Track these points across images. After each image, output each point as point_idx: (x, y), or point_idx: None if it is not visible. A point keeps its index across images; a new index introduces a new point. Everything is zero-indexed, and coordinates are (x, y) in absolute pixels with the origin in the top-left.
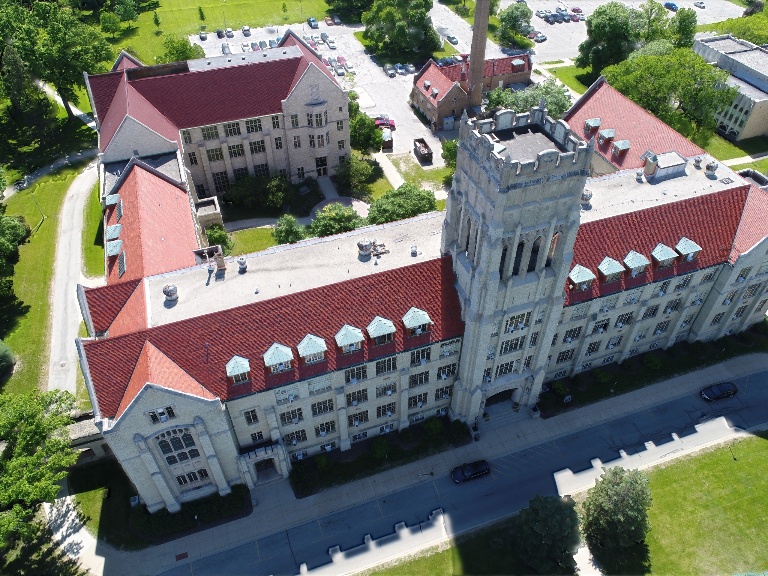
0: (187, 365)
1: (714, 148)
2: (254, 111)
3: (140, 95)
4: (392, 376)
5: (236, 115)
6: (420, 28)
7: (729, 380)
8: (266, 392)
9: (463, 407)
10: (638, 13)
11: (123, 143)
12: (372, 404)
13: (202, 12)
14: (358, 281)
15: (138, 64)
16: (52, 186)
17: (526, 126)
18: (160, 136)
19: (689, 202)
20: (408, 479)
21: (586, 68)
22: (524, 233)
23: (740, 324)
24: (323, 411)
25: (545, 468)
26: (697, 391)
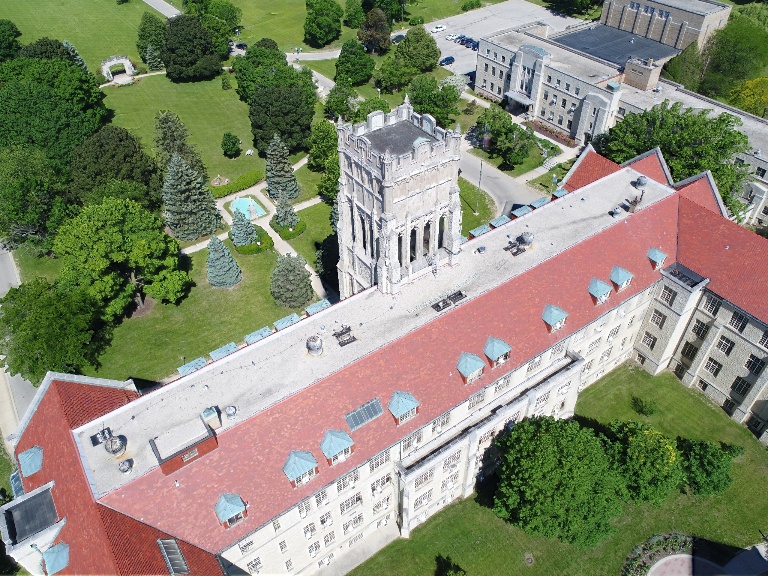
0: None
1: None
2: None
3: None
4: None
5: None
6: None
7: None
8: None
9: None
10: None
11: None
12: None
13: None
14: None
15: None
16: None
17: None
18: None
19: None
20: None
21: None
22: None
23: None
24: None
25: None
26: None
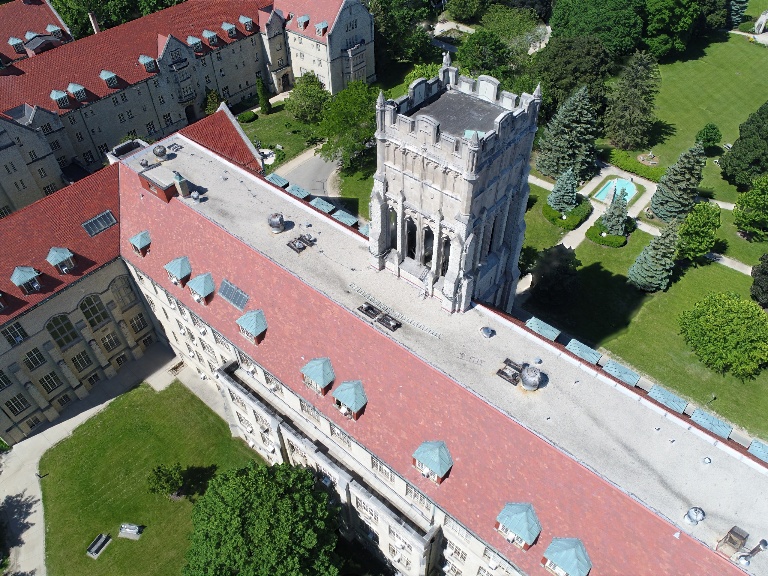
0: None
1: None
2: None
3: None
4: None
5: None
6: None
7: None
8: None
9: None
10: None
11: None
12: None
13: None
14: None
15: None
16: None
17: None
18: None
19: None
20: None
21: None
22: None
23: None
24: None
25: None
26: None
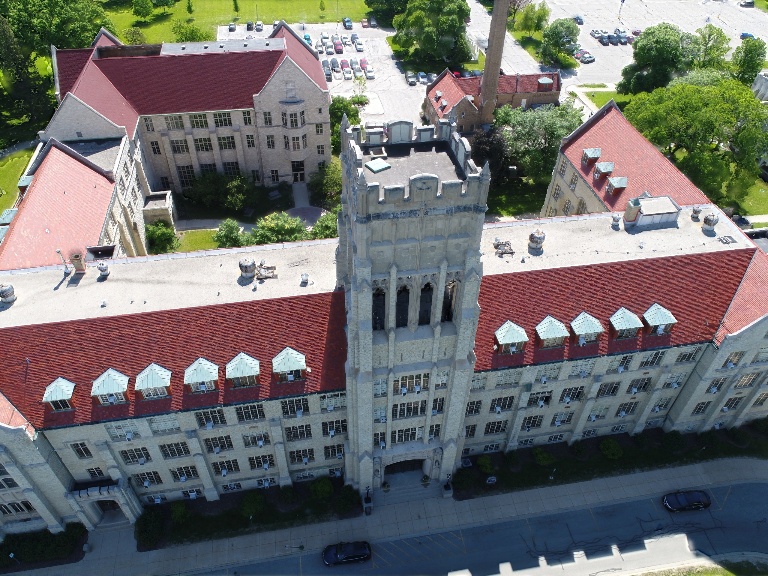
0: (0, 381)
1: (759, 199)
2: (223, 104)
3: (103, 75)
4: (260, 425)
5: (203, 106)
6: (450, 36)
7: (705, 487)
8: (93, 425)
9: (354, 472)
10: (693, 38)
11: (65, 123)
12: (241, 453)
13: (236, 3)
14: (224, 308)
15: (118, 44)
16: (25, 162)
17: (431, 142)
18: (105, 119)
19: (669, 261)
20: (272, 549)
21: (630, 95)
22: (404, 277)
23: (733, 418)
24: (177, 454)
25: (440, 564)
26: (659, 495)
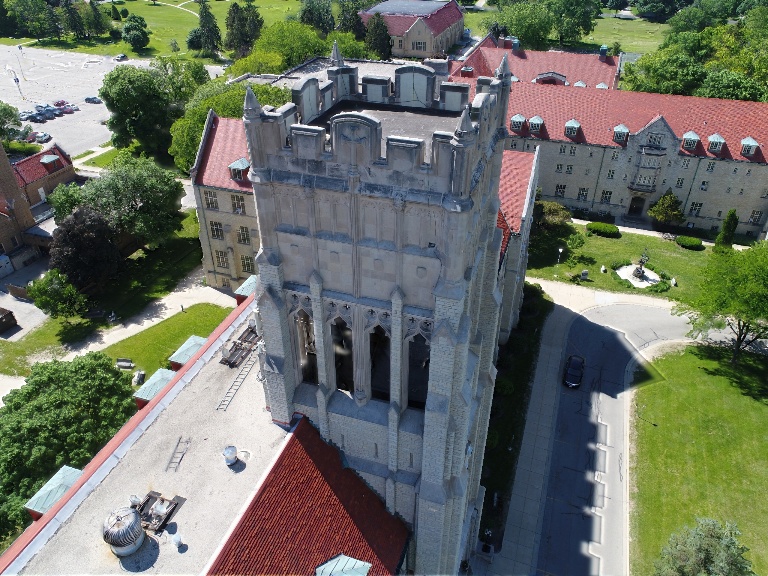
0: None
1: None
2: None
3: None
4: None
5: None
6: None
7: (563, 355)
8: None
9: None
10: (154, 72)
11: None
12: None
13: None
14: None
15: None
16: None
17: (333, 108)
18: None
19: None
20: None
21: None
22: None
23: None
24: None
25: None
26: (560, 385)
